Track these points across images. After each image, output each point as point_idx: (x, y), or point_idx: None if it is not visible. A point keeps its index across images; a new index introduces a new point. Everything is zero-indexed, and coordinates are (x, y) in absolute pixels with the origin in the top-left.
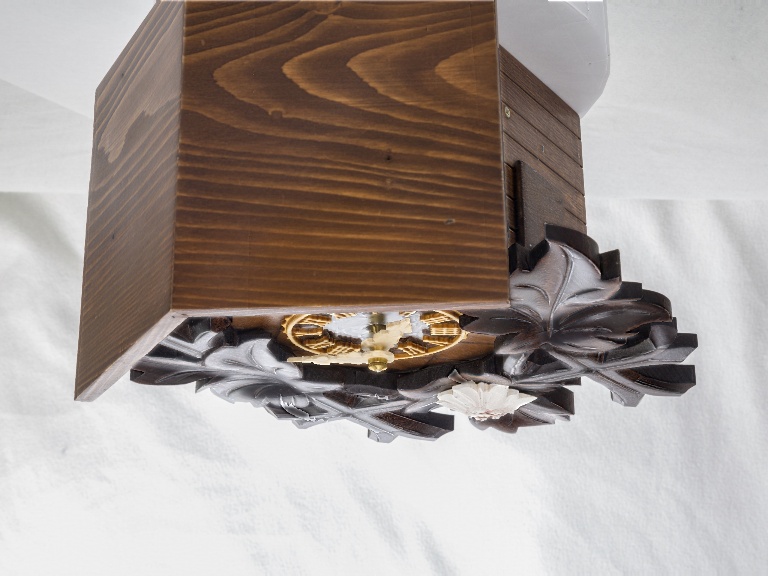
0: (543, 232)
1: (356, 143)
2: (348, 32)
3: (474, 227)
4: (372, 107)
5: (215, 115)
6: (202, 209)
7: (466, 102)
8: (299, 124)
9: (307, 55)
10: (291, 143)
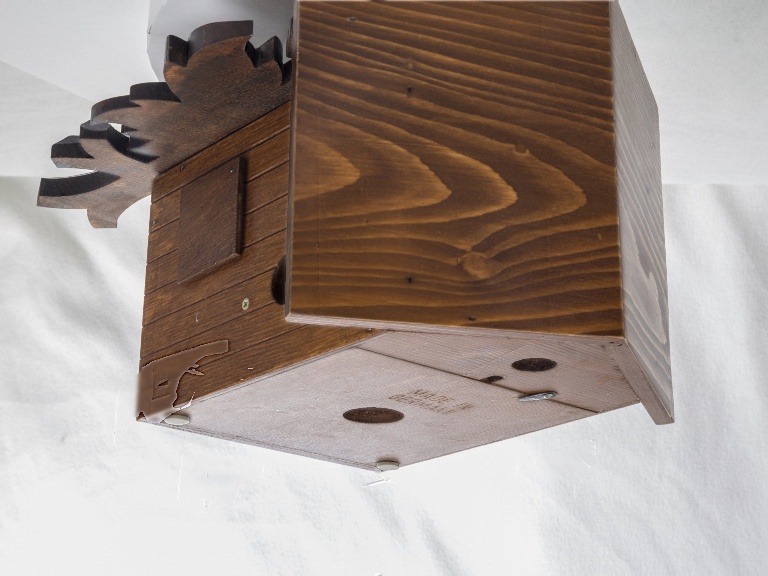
0: (212, 206)
1: (442, 108)
2: (450, 228)
3: (329, 11)
4: (426, 143)
5: (582, 156)
6: (588, 65)
7: (330, 135)
8: (499, 136)
9: (492, 208)
10: (506, 117)
